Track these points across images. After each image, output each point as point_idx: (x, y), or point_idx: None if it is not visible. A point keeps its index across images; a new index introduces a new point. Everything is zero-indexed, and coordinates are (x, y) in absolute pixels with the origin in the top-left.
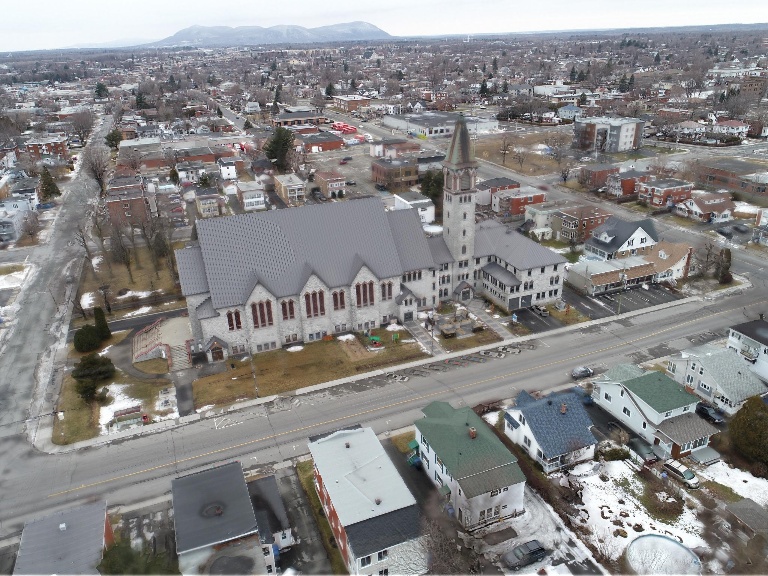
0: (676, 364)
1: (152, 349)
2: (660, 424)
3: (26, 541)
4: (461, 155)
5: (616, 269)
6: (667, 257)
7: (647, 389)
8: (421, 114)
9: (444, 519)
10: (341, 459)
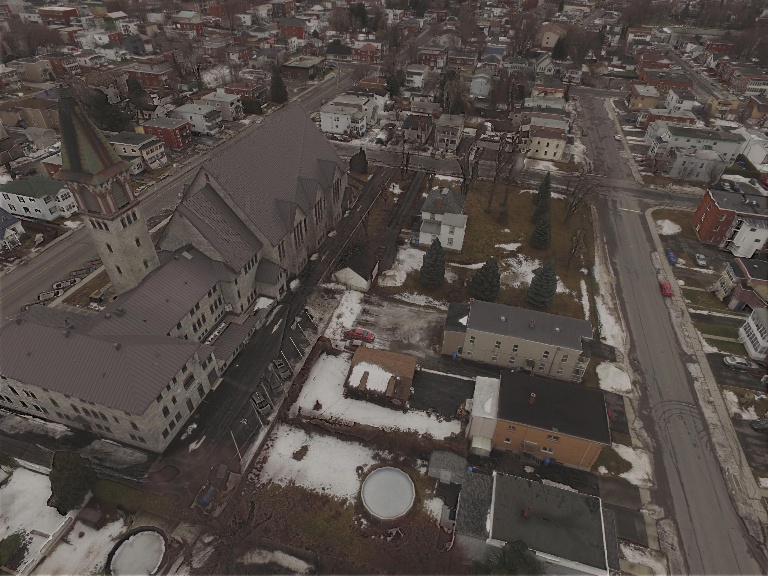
0: None
1: None
2: None
3: None
4: None
5: None
6: None
7: None
8: None
9: None
10: None
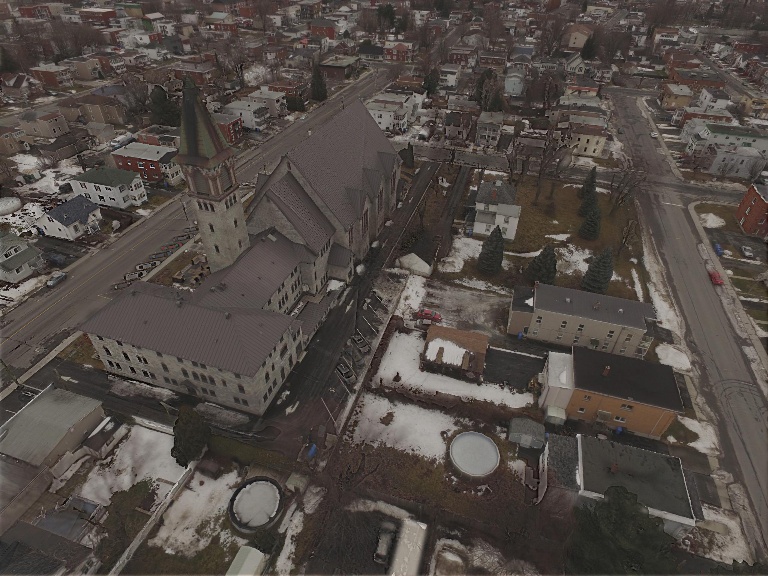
0: None
1: None
2: None
3: None
4: None
5: (8, 437)
6: None
7: None
8: None
9: None
10: (156, 150)
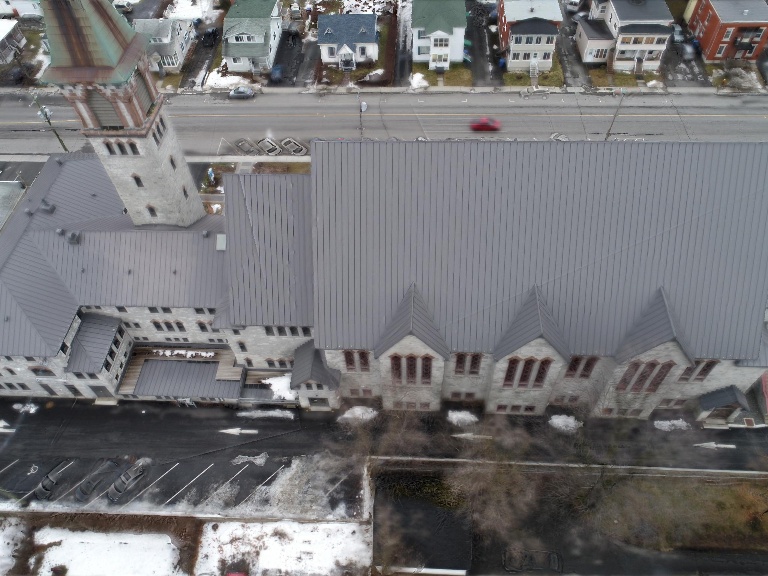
0: None
1: None
2: None
3: (767, 11)
4: None
5: None
6: None
7: (259, 10)
8: None
9: (469, 25)
10: (540, 5)
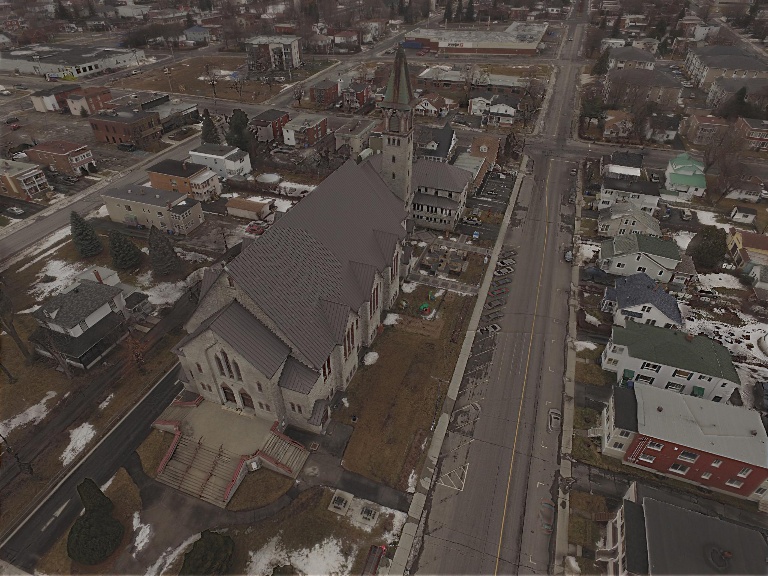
0: (610, 225)
1: (239, 471)
2: (675, 268)
3: None
4: (408, 93)
5: (475, 169)
6: (487, 150)
7: (654, 248)
8: (32, 50)
9: None
10: (677, 424)
